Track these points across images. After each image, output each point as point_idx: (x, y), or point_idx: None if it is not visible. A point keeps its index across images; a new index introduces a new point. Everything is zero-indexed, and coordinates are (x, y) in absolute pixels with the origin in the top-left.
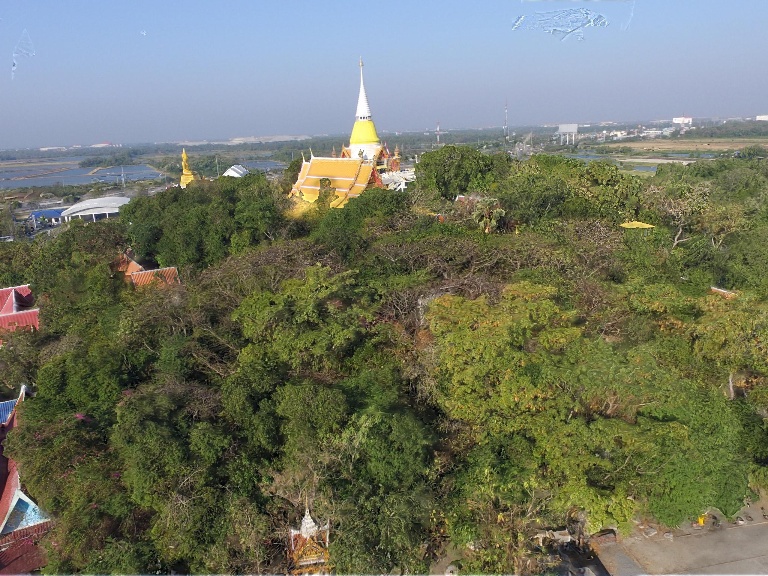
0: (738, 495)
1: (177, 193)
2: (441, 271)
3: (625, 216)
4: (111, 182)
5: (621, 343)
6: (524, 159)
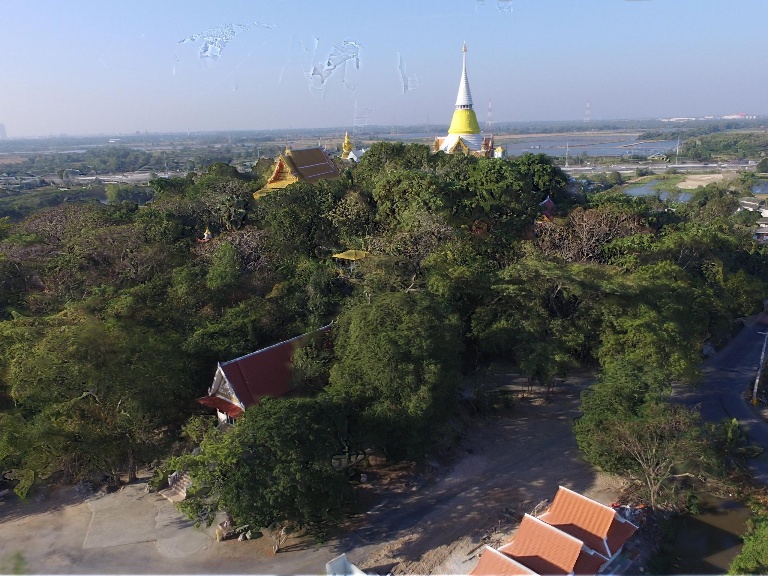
0: None
1: None
2: None
3: None
4: (575, 156)
5: None
6: None
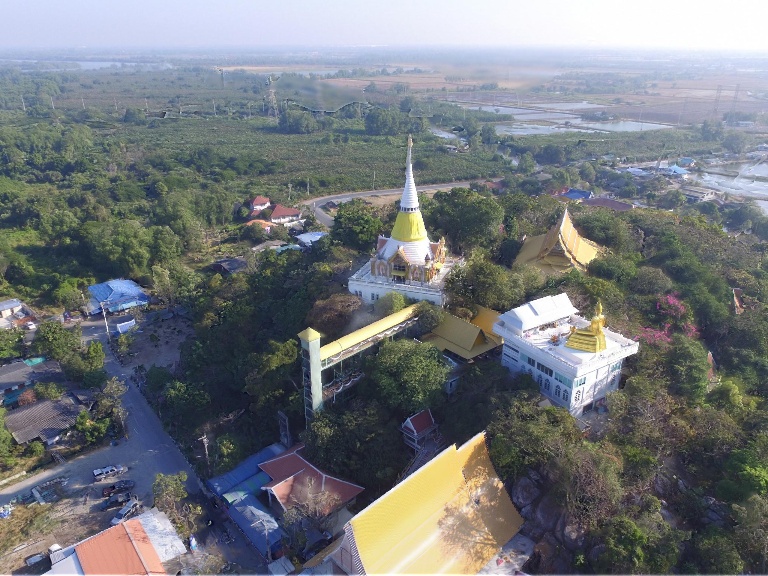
0: None
1: None
2: None
3: None
4: None
5: None
6: None
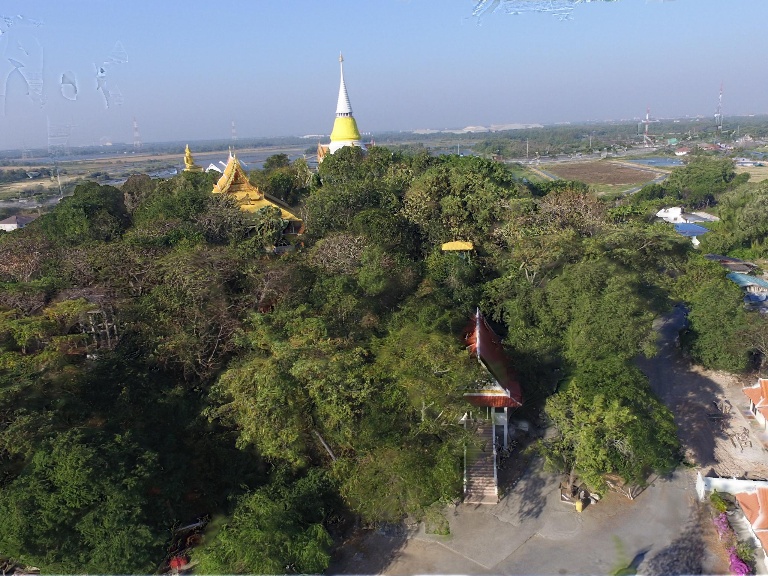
0: (110, 570)
1: (89, 187)
2: (127, 279)
3: (464, 234)
4: None
5: (210, 378)
6: (729, 153)
